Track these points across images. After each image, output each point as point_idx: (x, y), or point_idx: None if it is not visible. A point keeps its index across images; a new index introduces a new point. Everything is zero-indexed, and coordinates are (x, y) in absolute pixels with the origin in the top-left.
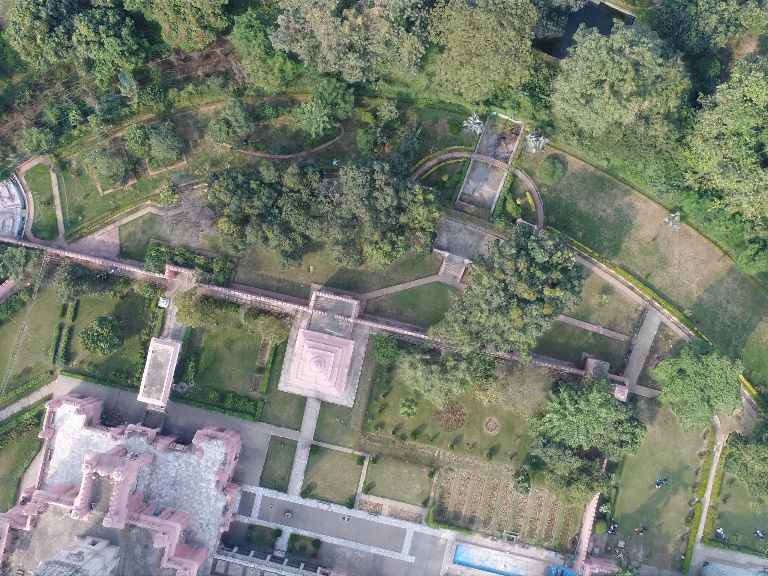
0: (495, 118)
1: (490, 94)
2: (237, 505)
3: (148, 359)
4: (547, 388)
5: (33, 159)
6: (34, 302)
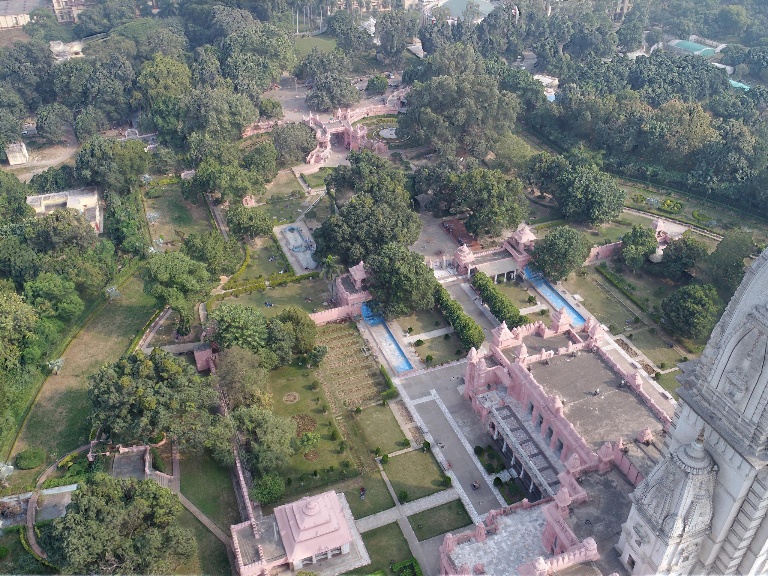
0: None
1: None
2: None
3: None
4: None
5: None
6: None
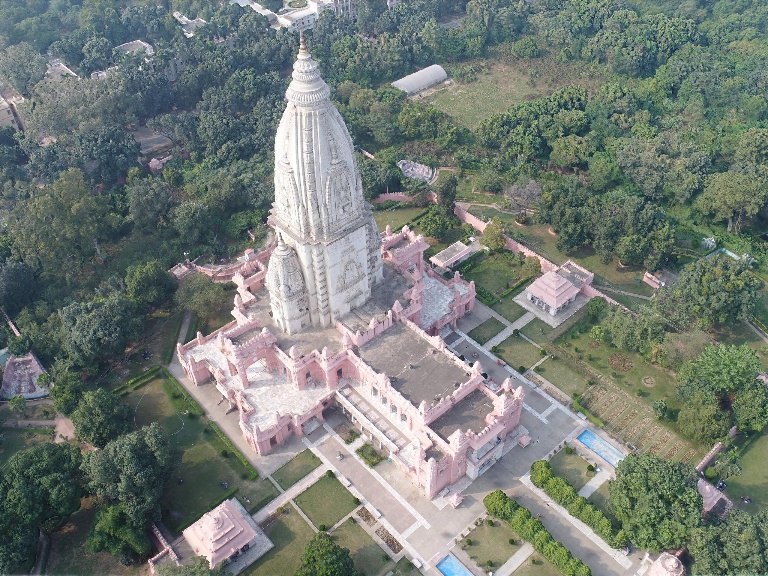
0: (723, 253)
1: (729, 215)
2: (446, 335)
3: (450, 246)
4: (708, 344)
5: (449, 168)
6: (403, 211)
